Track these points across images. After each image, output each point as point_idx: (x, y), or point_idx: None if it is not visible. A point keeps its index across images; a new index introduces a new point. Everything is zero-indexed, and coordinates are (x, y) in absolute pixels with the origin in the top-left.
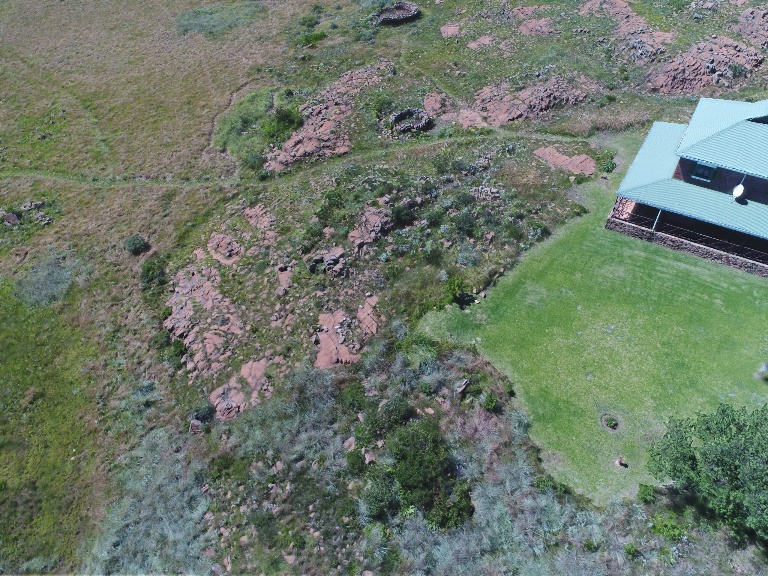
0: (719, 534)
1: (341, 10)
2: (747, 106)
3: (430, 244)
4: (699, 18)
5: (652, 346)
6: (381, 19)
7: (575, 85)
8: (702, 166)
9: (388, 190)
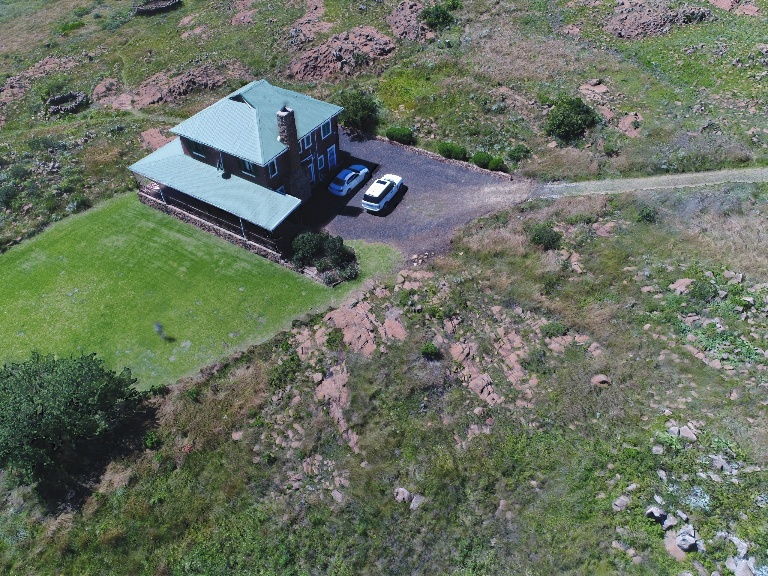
0: (12, 471)
1: (118, 1)
2: None
3: None
4: (363, 9)
5: (96, 308)
6: (136, 10)
7: (223, 71)
8: (195, 142)
9: None
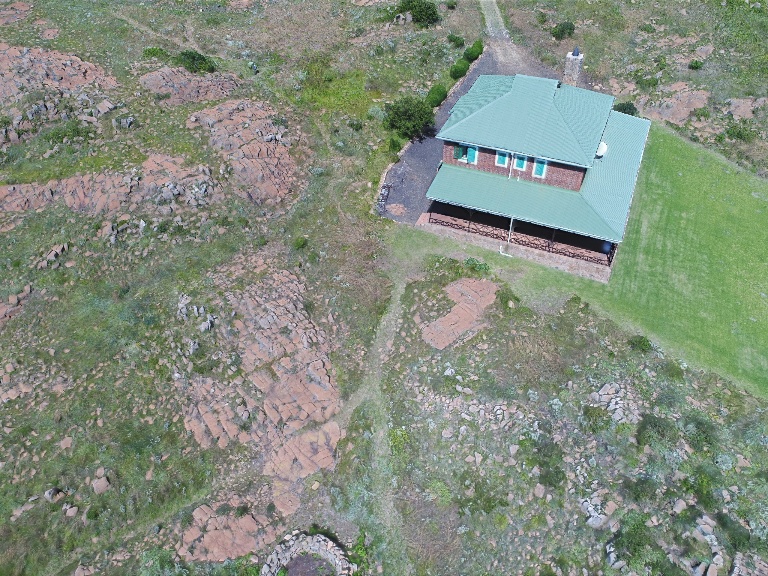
0: None
1: None
2: (516, 96)
3: (763, 486)
4: (132, 121)
5: None
6: None
7: (253, 279)
8: None
9: (680, 571)
